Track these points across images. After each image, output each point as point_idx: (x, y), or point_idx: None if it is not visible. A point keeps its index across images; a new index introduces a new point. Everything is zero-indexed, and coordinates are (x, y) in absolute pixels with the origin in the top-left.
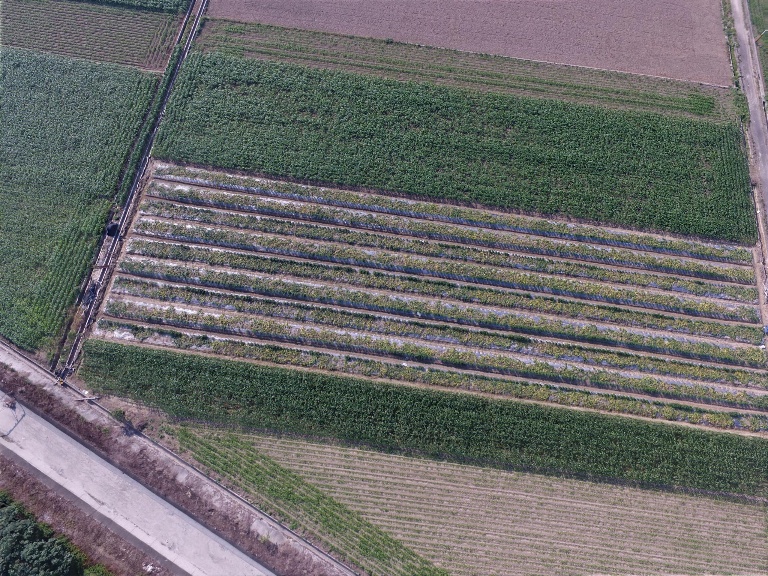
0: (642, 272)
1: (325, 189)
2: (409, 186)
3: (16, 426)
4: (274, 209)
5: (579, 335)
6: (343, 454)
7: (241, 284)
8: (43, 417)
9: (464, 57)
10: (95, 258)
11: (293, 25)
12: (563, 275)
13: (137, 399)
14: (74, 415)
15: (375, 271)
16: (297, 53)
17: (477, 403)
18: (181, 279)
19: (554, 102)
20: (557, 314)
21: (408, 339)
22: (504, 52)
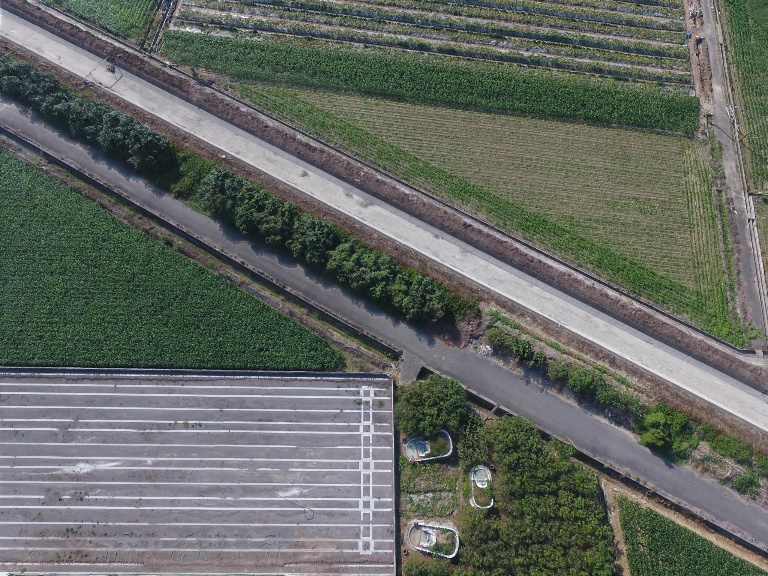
0: None
1: None
2: None
3: (116, 83)
4: None
5: (543, 35)
6: (363, 101)
7: (282, 0)
8: (137, 75)
9: None
10: None
11: None
12: None
13: (206, 67)
14: (161, 71)
15: None
16: None
17: (464, 70)
18: None
19: None
20: (527, 23)
21: (411, 37)
22: None
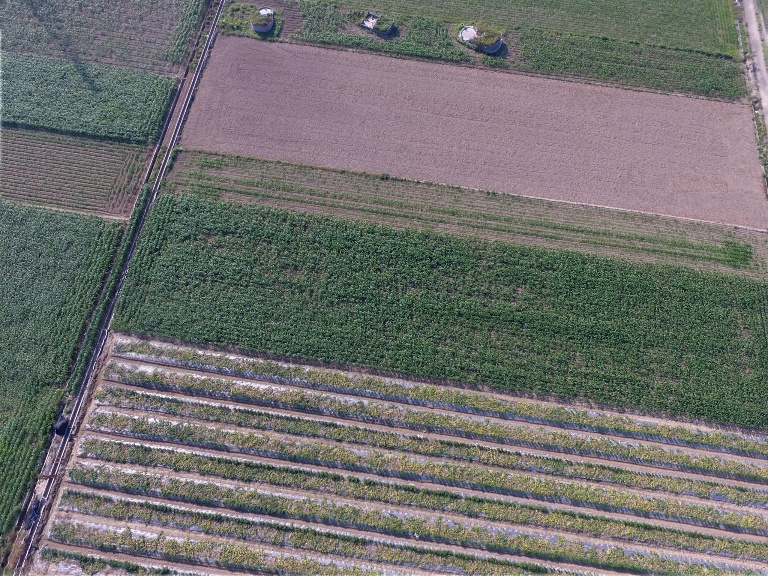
0: (675, 475)
1: (309, 369)
2: (406, 366)
3: None
4: (250, 396)
5: (603, 563)
6: None
7: (210, 498)
8: None
9: (469, 196)
10: (41, 464)
11: (277, 157)
12: (583, 479)
13: None
14: None
15: (366, 478)
16: (280, 193)
17: None
18: (140, 491)
19: (571, 254)
20: (577, 532)
21: (404, 569)
22: (514, 189)
